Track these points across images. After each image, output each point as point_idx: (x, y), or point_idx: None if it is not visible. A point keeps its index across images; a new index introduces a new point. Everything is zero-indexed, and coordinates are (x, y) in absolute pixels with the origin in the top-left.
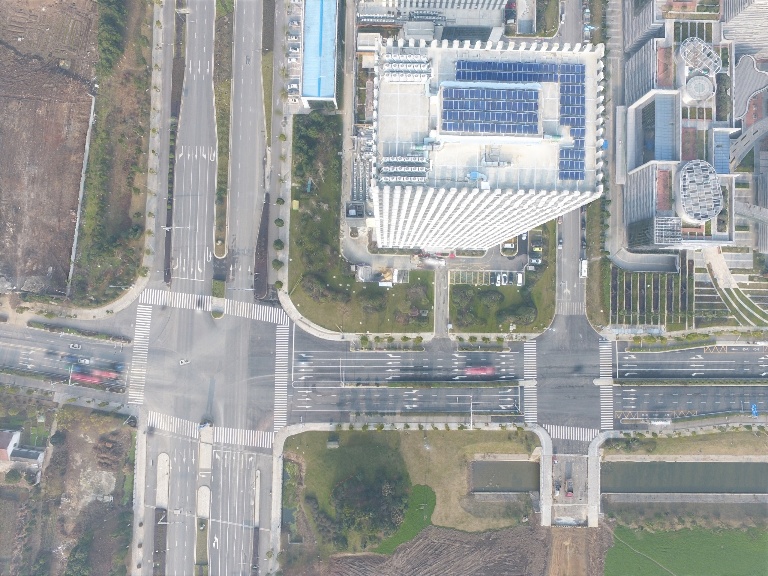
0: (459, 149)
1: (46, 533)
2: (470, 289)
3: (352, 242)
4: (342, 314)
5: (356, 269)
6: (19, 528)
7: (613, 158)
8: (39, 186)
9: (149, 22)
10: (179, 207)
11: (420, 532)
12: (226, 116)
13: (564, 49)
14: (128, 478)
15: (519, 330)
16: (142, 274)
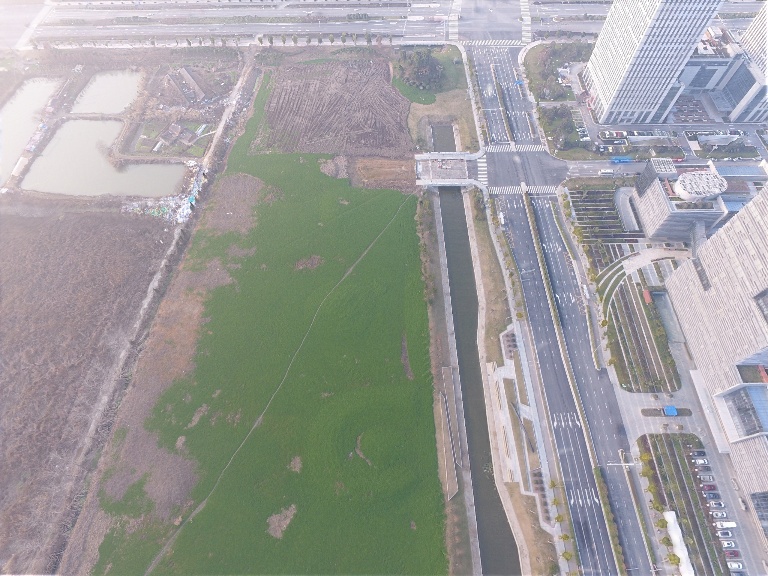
0: None
1: None
2: (571, 115)
3: (581, 67)
4: None
5: (565, 68)
6: None
7: None
8: None
9: None
10: (576, 6)
11: (406, 98)
12: None
13: None
14: None
15: (549, 142)
16: None
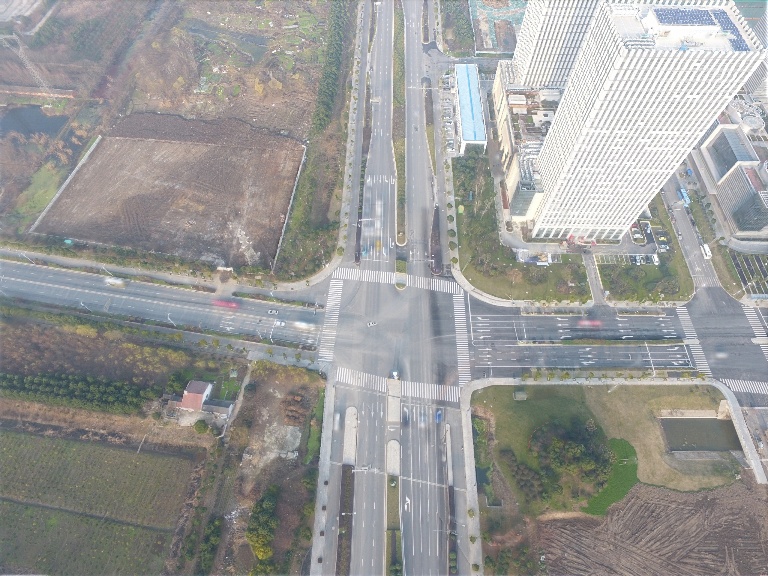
0: (667, 40)
1: (221, 494)
2: None
3: (509, 235)
4: (515, 277)
5: (516, 253)
6: (190, 492)
7: (699, 181)
8: (257, 199)
9: (347, 110)
10: (367, 212)
11: (629, 490)
12: (403, 158)
13: (710, 3)
14: (313, 435)
15: (668, 298)
16: (341, 251)
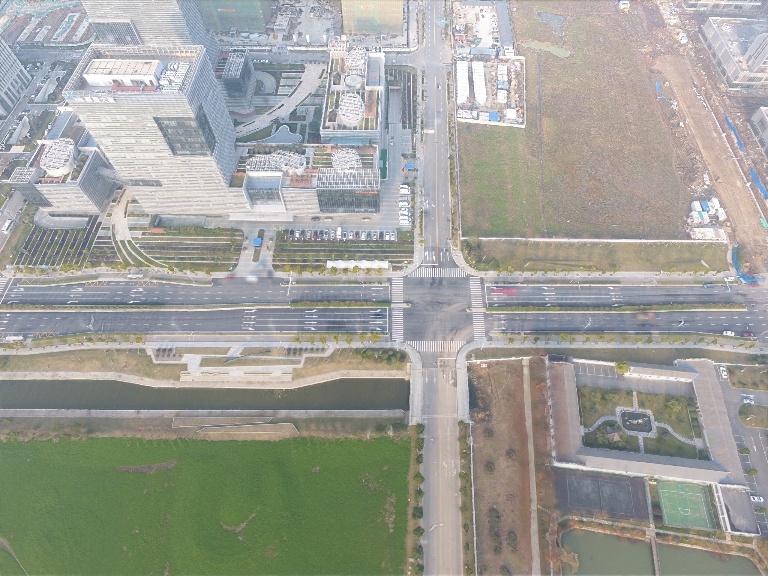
0: None
1: None
2: None
3: None
4: None
5: None
6: None
7: None
8: None
9: None
10: None
11: None
12: None
13: None
14: None
15: None
16: None
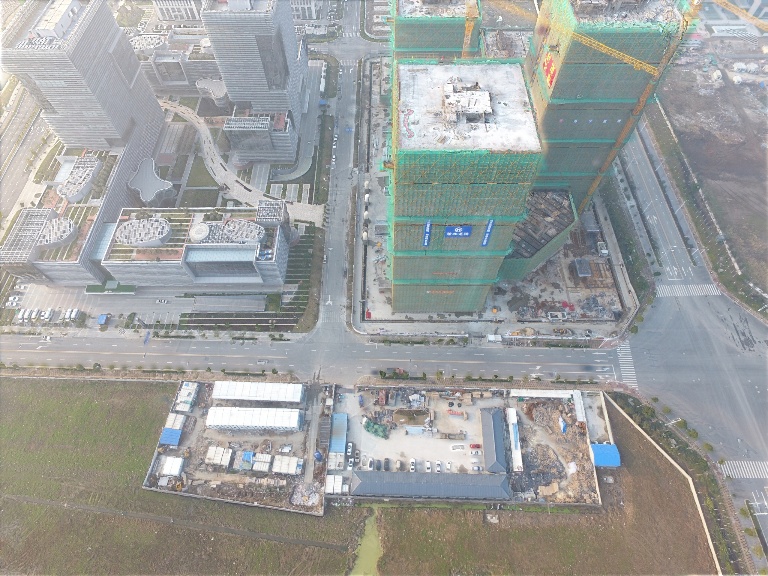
0: None
1: None
2: (140, 14)
3: None
4: None
5: None
6: None
7: None
8: None
9: None
10: None
11: (19, 2)
12: None
13: None
14: None
15: None
16: None
